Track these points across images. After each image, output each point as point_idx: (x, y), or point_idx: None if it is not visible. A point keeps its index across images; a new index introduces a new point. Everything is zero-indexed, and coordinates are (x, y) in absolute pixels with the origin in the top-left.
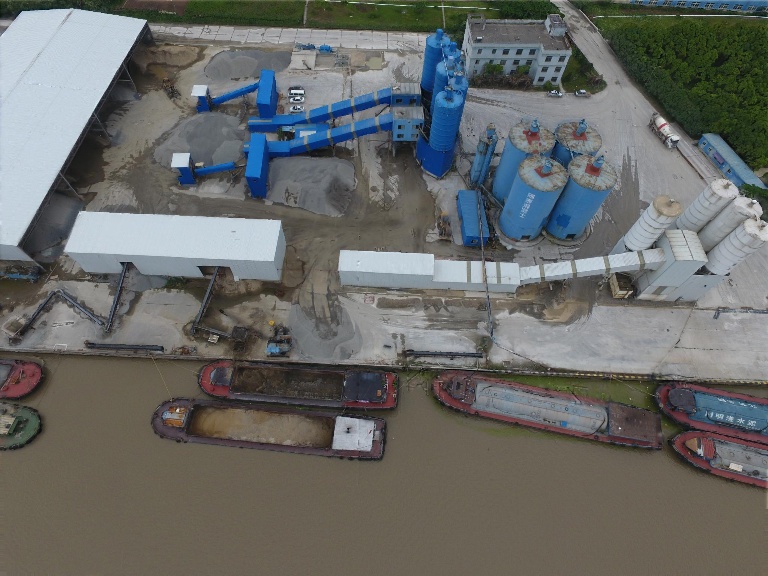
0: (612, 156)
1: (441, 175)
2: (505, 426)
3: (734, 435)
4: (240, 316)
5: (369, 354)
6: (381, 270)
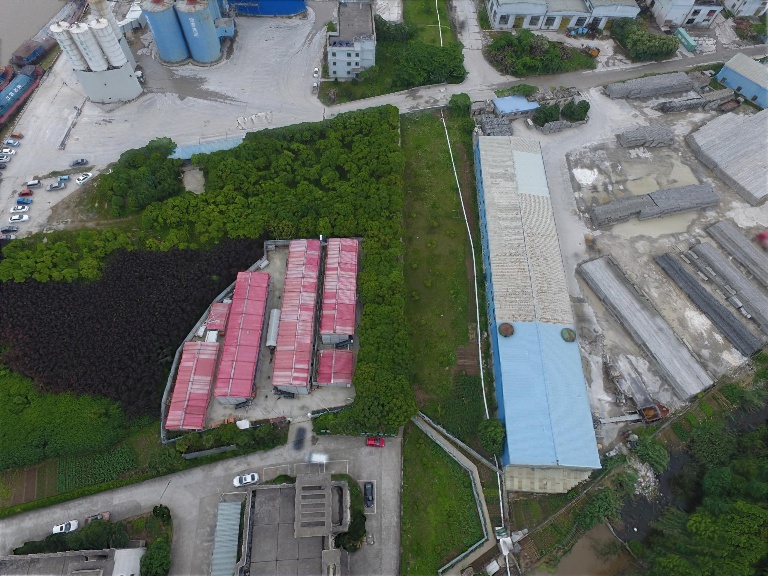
0: (237, 91)
1: (230, 7)
2: None
3: (0, 92)
4: None
5: None
6: None
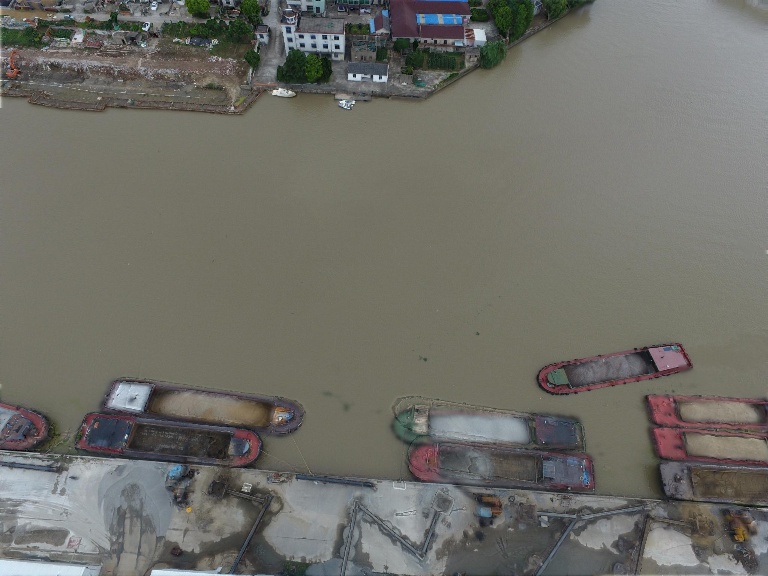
0: None
1: None
2: (1, 400)
3: None
4: (224, 521)
5: (96, 471)
6: (32, 567)
